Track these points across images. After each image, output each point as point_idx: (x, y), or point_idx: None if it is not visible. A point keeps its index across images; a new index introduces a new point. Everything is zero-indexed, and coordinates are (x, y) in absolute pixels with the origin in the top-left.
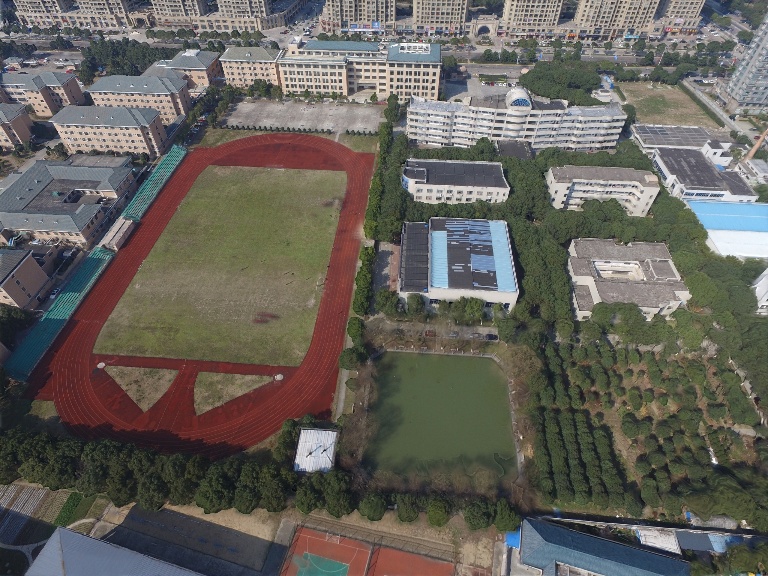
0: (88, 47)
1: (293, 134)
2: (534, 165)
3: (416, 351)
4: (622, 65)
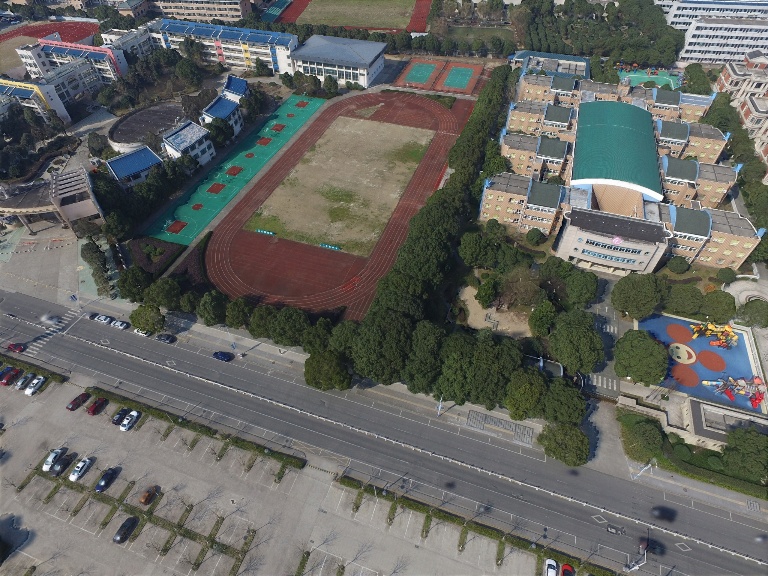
0: None
1: None
2: None
3: (466, 26)
4: None
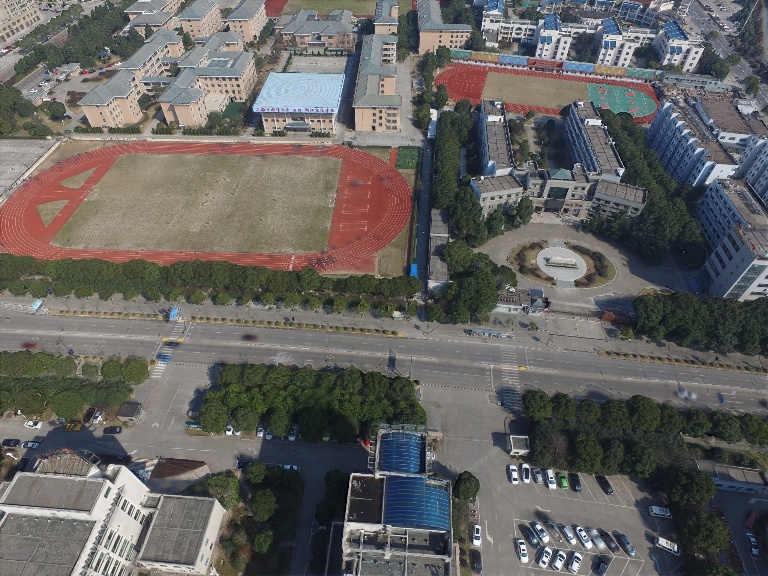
0: (10, 78)
1: None
2: None
3: None
4: None
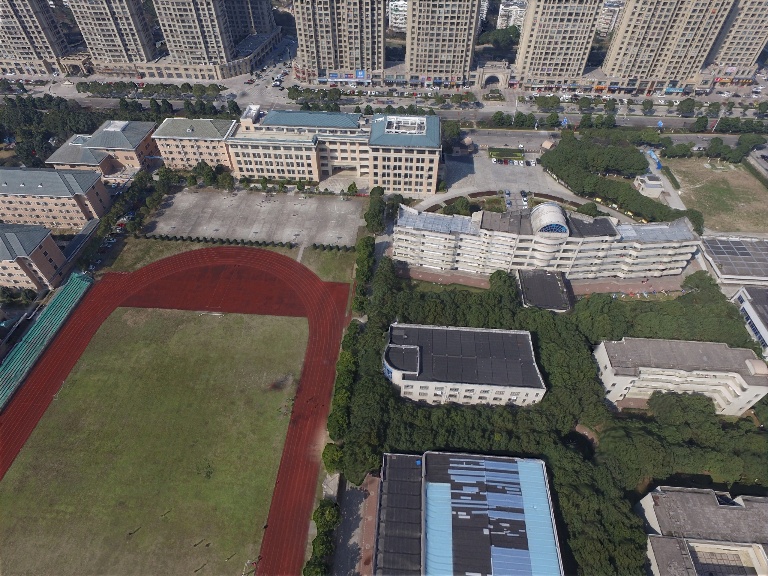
0: (4, 104)
1: (241, 248)
2: (577, 331)
3: None
4: (667, 131)
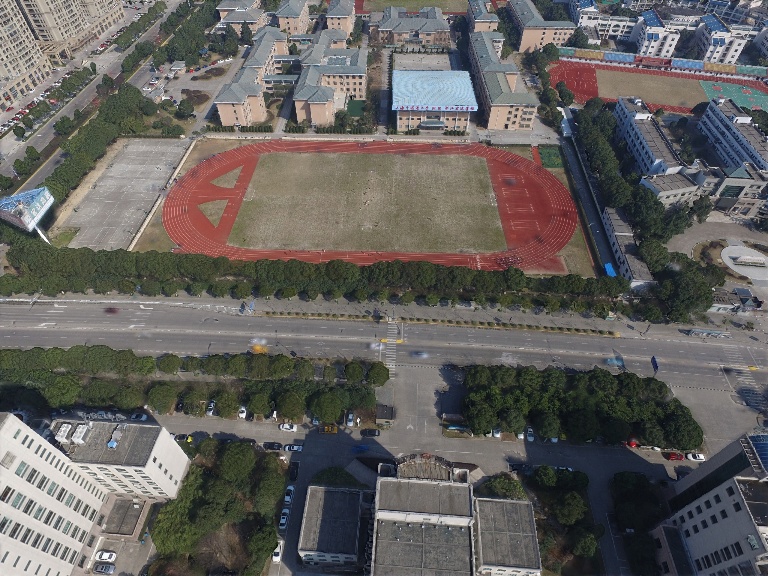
0: (118, 76)
1: None
2: None
3: None
4: None
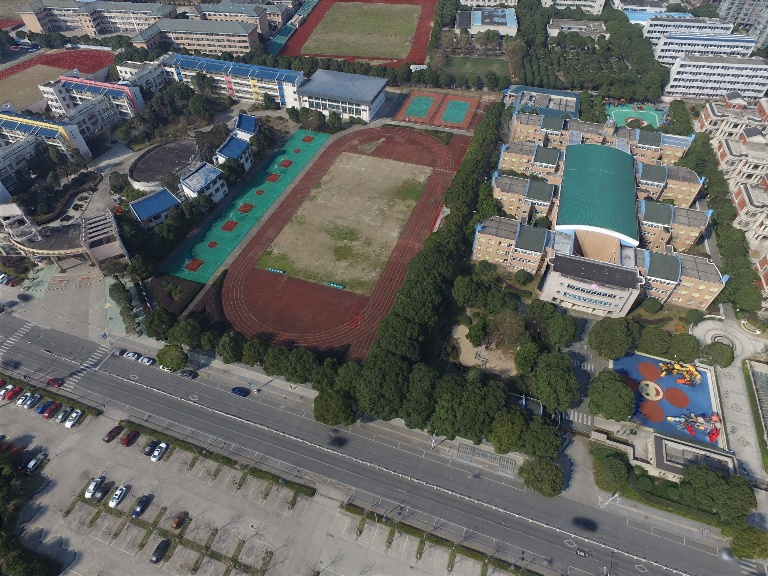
0: None
1: None
2: None
3: (463, 56)
4: None
